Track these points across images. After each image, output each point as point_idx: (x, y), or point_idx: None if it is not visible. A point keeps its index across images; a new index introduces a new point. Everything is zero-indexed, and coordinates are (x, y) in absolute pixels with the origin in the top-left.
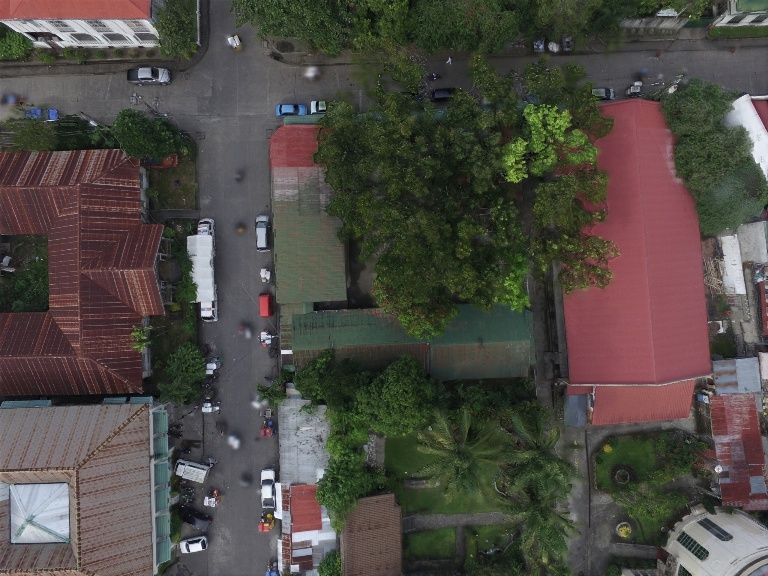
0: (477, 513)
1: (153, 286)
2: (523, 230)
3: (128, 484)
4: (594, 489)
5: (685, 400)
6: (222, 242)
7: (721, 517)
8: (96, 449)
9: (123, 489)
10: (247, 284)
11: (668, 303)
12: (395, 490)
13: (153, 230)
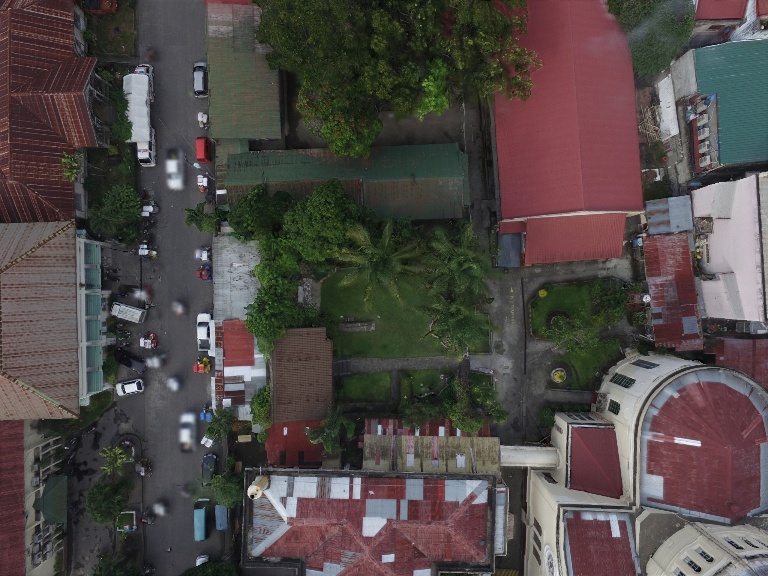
0: (412, 358)
1: (84, 113)
2: (443, 35)
3: (53, 297)
4: (530, 335)
5: (617, 237)
6: (161, 89)
7: (653, 357)
8: (19, 257)
9: (47, 301)
10: (185, 131)
11: (598, 135)
12: (329, 331)
13: (86, 62)
